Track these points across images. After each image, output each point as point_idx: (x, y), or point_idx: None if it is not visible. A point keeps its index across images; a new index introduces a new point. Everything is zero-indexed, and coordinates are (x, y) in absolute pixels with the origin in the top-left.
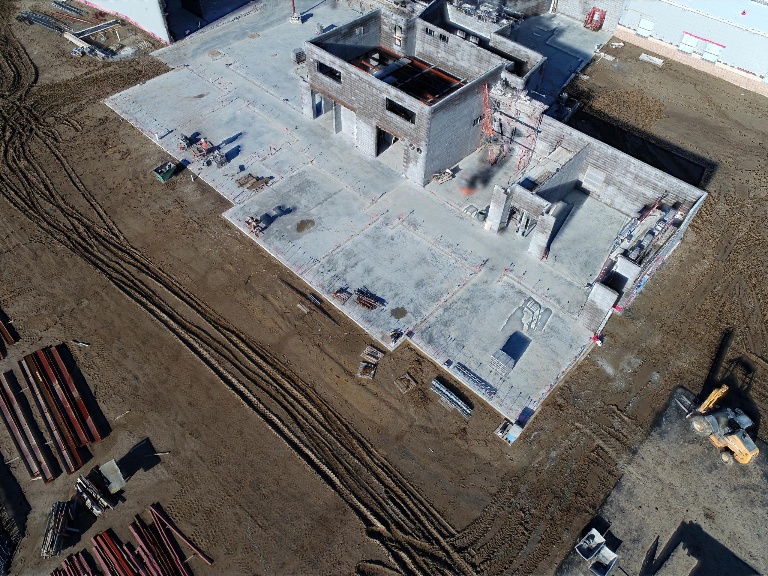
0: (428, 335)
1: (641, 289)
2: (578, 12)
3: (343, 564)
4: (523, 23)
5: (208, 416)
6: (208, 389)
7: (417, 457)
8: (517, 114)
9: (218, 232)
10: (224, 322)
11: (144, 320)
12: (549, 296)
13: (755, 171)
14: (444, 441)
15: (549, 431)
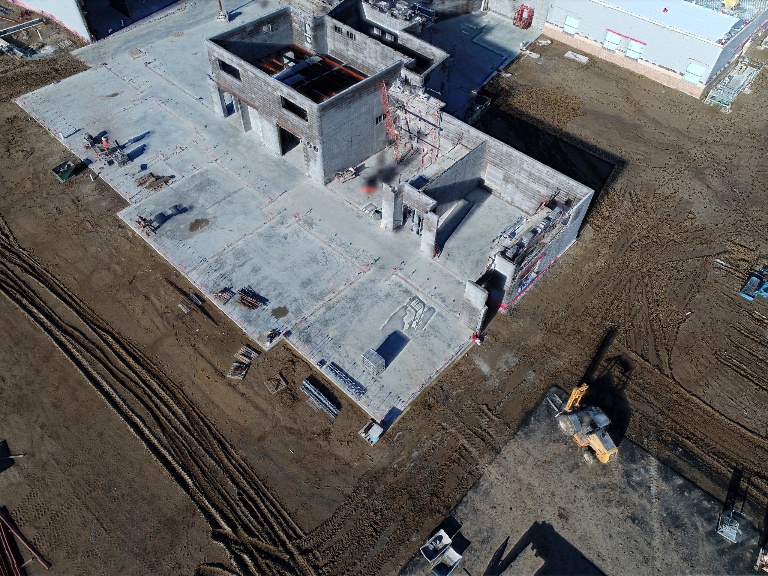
0: (306, 335)
1: (530, 287)
2: (508, 10)
3: (183, 567)
4: (453, 21)
5: (70, 418)
6: (74, 390)
7: (276, 458)
8: (420, 112)
9: (110, 232)
10: (102, 323)
11: (21, 321)
12: (435, 295)
13: (665, 168)
14: (306, 442)
15: (414, 431)
